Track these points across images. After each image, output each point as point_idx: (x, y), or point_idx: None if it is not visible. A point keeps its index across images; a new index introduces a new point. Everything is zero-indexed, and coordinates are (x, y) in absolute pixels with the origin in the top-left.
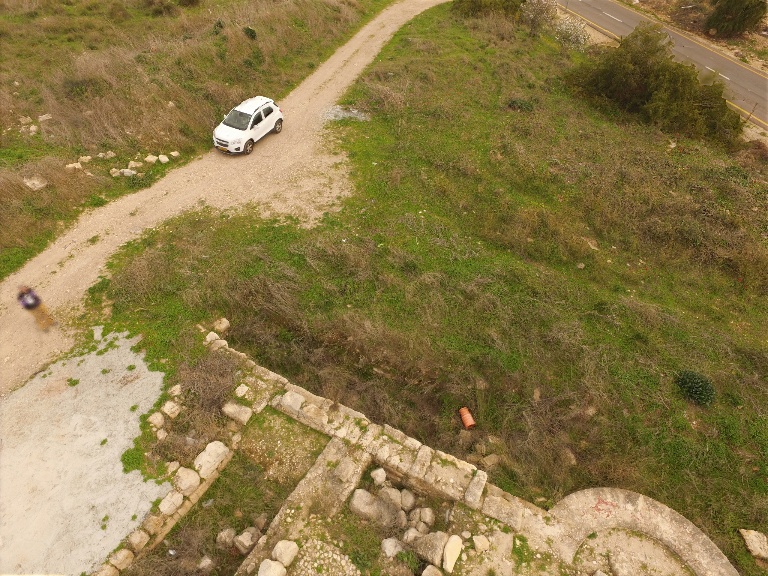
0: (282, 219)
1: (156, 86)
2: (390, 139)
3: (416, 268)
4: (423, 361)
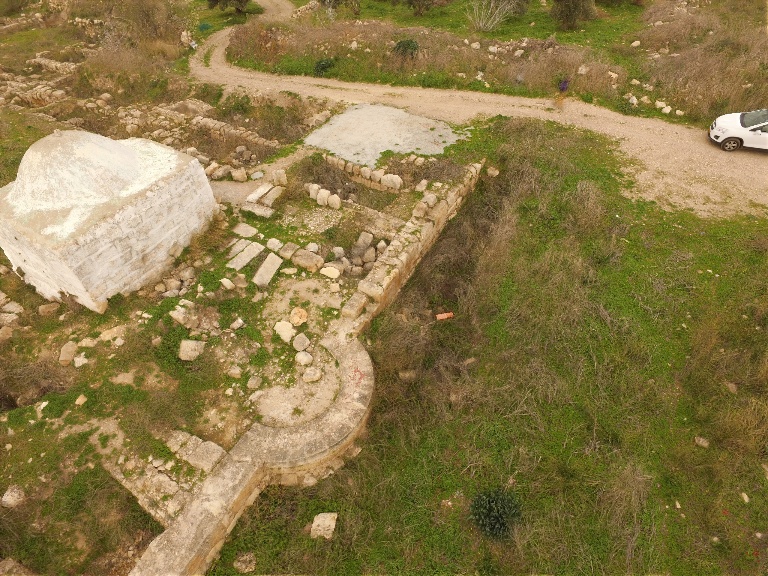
0: (626, 179)
1: (756, 65)
2: None
3: (601, 264)
4: (481, 267)
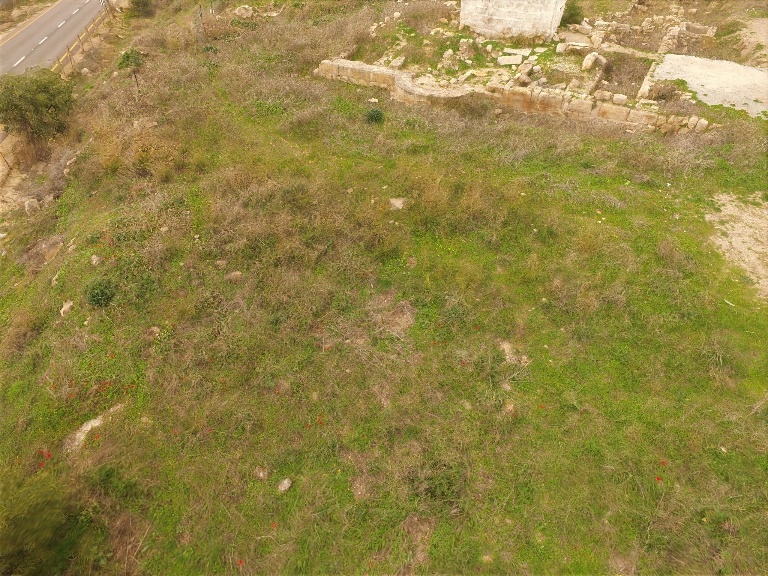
0: (762, 202)
1: None
2: (759, 391)
3: None
4: None
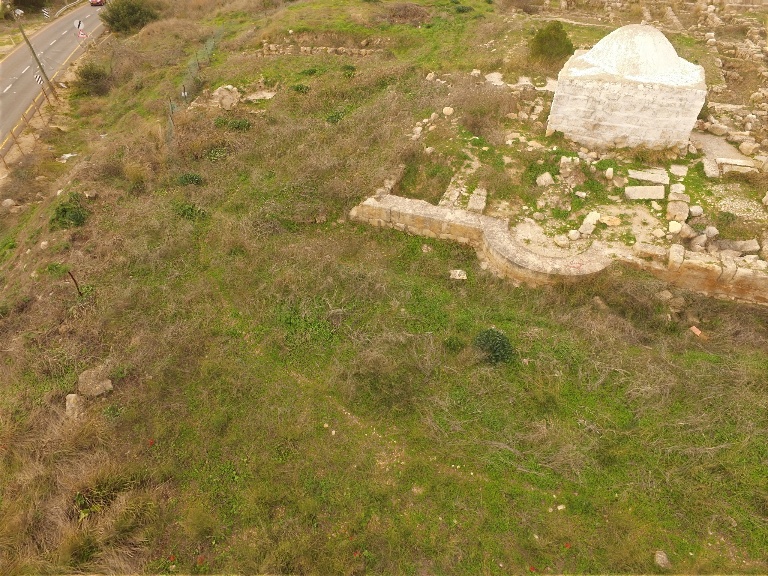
0: None
1: None
2: None
3: None
4: None
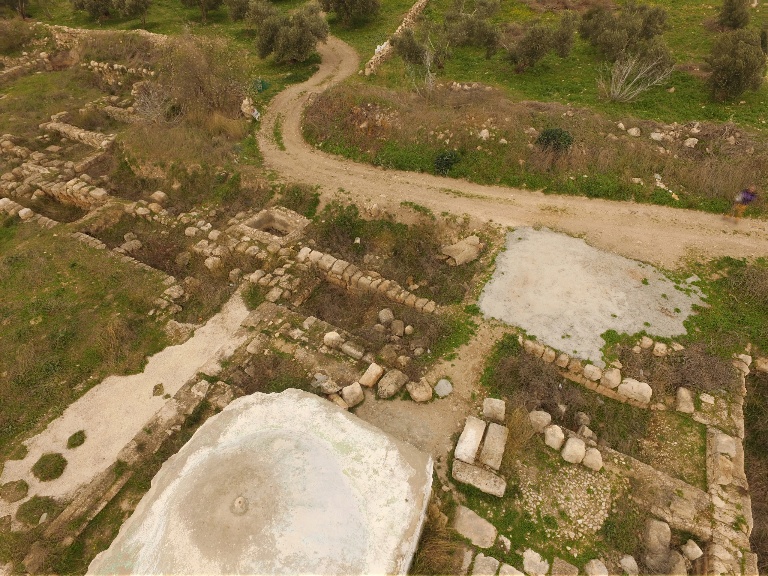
0: None
1: None
2: None
3: None
4: None
